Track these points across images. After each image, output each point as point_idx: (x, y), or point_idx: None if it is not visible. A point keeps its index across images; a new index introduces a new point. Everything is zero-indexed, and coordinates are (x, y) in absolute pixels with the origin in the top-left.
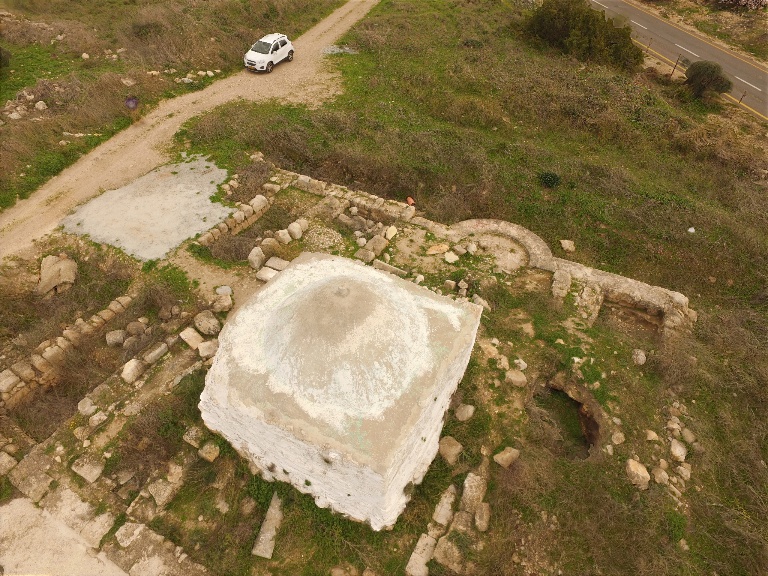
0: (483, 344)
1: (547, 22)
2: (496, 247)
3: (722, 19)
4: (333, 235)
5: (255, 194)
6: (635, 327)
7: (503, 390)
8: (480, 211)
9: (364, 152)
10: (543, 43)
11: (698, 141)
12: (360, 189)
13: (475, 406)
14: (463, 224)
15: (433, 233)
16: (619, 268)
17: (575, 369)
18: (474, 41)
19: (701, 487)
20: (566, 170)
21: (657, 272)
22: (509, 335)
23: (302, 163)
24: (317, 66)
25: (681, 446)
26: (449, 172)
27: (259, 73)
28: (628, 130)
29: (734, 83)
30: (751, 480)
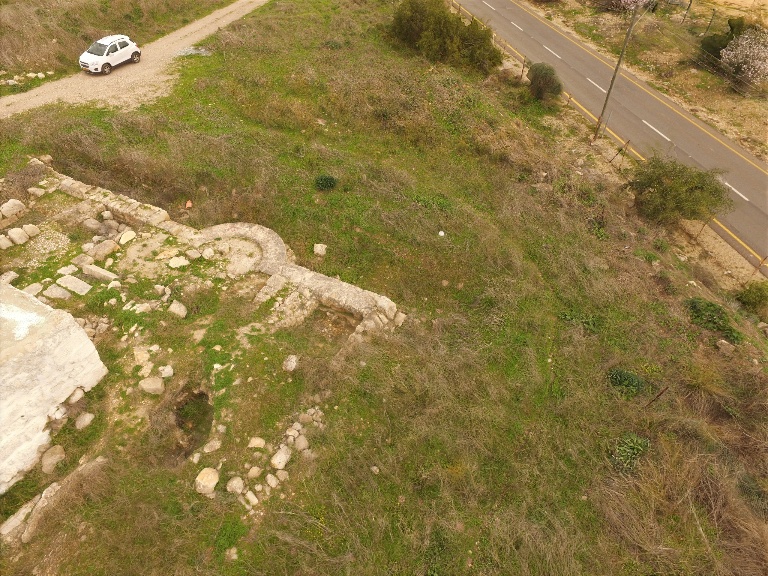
0: (138, 351)
1: (405, 24)
2: (237, 251)
3: (602, 21)
4: (61, 240)
5: (21, 198)
6: (341, 332)
7: (132, 398)
8: (246, 215)
9: (153, 155)
10: (402, 45)
11: (496, 143)
12: (137, 193)
13: (94, 414)
14: (215, 228)
15: (177, 237)
16: (362, 272)
17: (212, 376)
18: (333, 43)
19: (291, 495)
20: (351, 173)
21: (397, 276)
22: (174, 341)
23: (90, 166)
24: (160, 68)
25: (286, 453)
26: (231, 175)
27: (95, 75)
28: (432, 132)
29: (563, 85)
30: (344, 487)
